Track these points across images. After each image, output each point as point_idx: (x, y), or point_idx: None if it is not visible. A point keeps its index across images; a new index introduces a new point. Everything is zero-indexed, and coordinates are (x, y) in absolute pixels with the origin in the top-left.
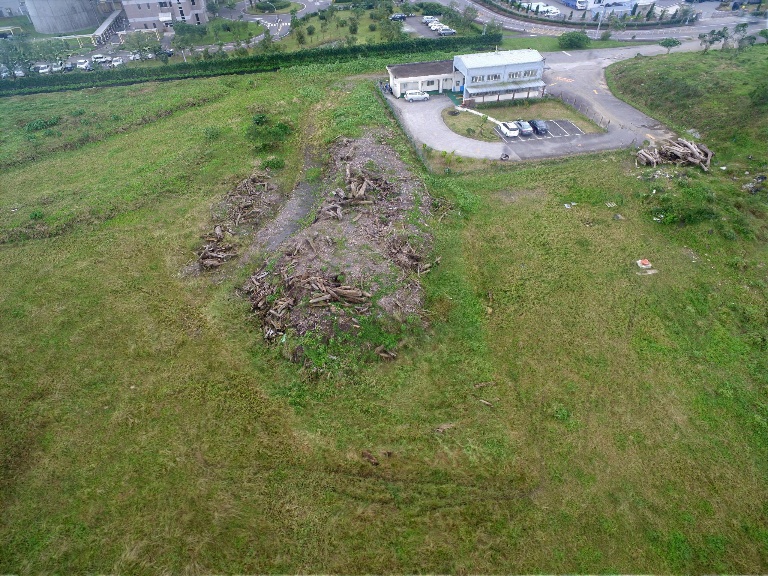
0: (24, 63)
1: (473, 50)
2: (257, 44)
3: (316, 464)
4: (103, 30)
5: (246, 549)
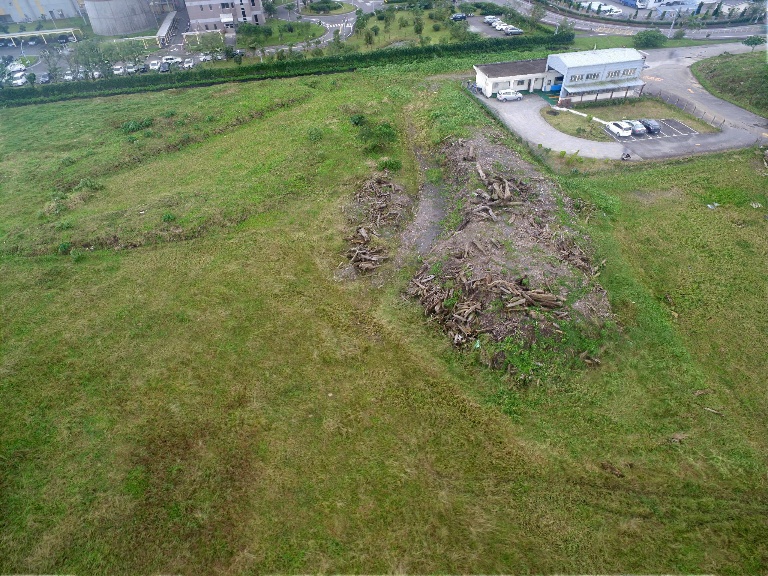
0: (104, 64)
1: (548, 49)
2: (332, 44)
3: (556, 476)
4: (166, 31)
5: (518, 567)
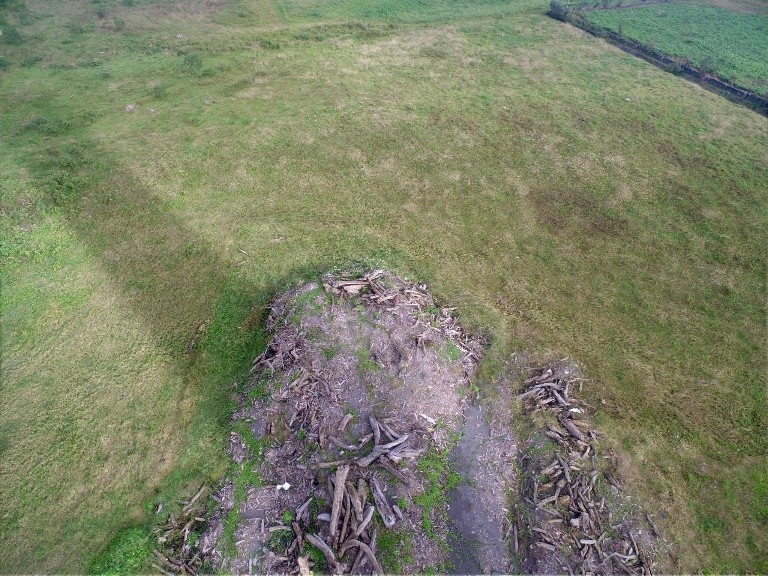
0: None
1: None
2: None
3: None
4: None
5: None
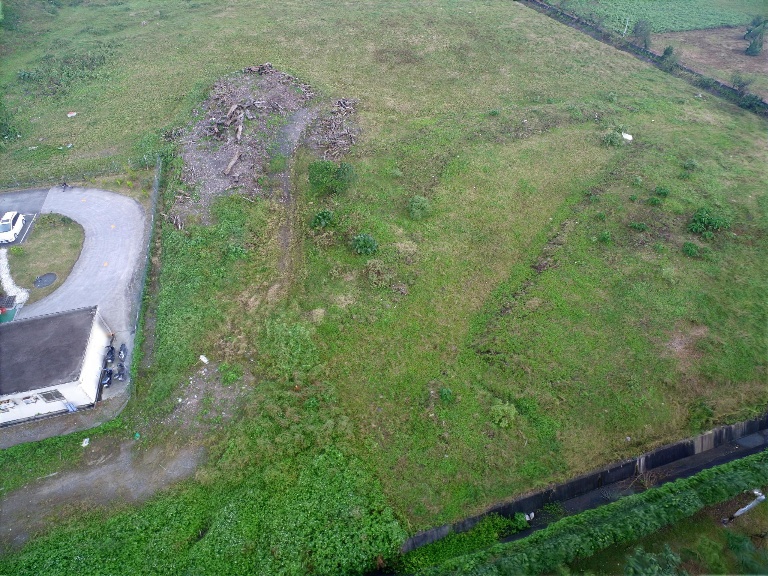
0: None
1: None
2: None
3: None
4: None
5: None
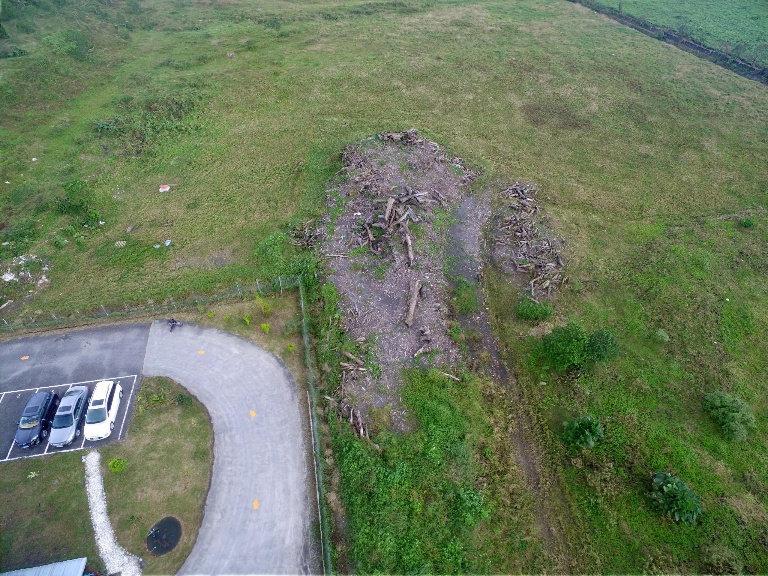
0: None
1: None
2: None
3: None
4: None
5: None
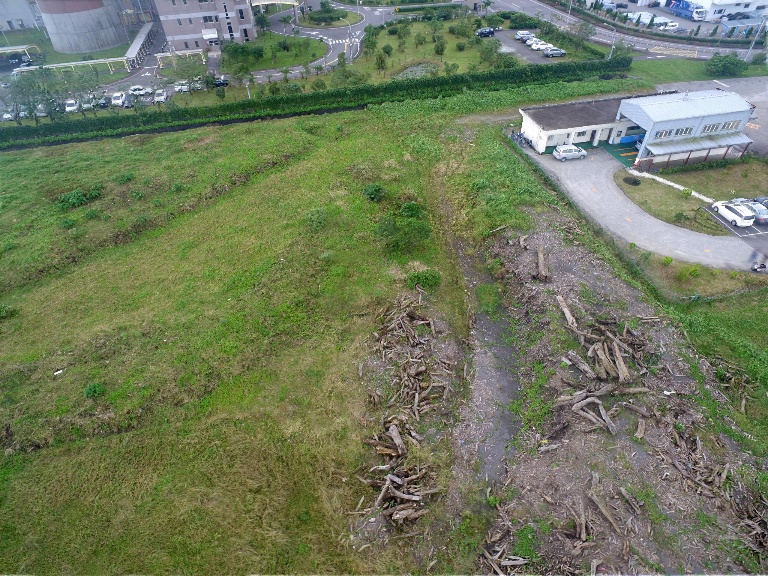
0: (49, 103)
1: (602, 79)
2: (337, 74)
3: None
4: (137, 51)
5: None
